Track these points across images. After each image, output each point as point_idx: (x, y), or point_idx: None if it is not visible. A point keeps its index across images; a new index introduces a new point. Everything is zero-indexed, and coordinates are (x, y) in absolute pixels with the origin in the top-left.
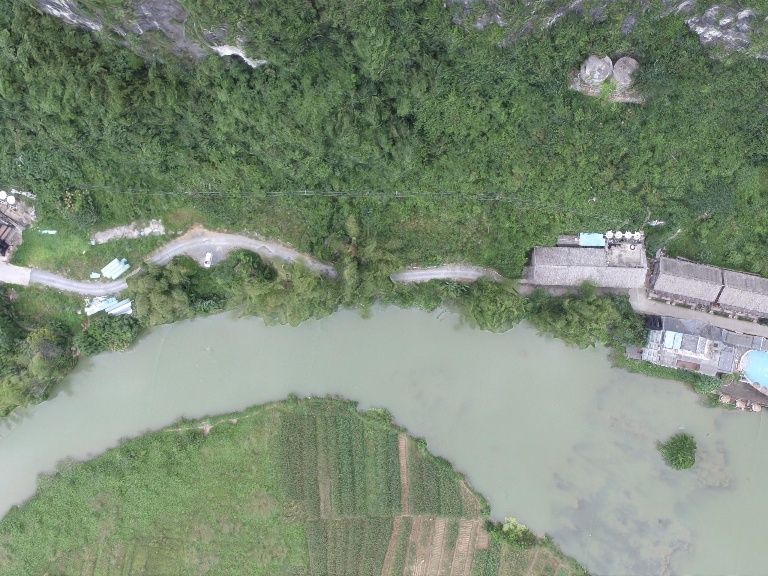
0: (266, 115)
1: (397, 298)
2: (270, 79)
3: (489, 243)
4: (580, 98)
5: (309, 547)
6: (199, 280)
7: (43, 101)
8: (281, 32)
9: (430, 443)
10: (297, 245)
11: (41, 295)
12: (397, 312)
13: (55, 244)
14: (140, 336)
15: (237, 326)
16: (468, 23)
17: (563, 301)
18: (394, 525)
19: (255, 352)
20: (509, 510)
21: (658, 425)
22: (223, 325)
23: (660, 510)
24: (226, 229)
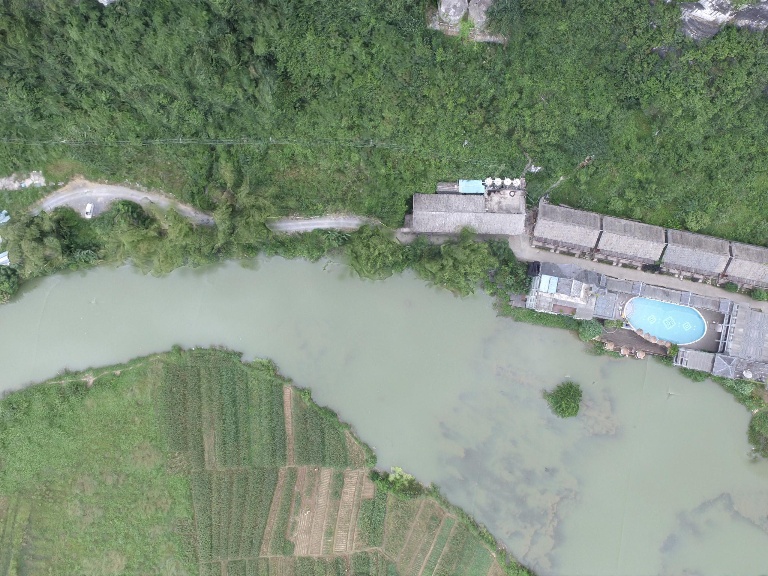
0: (122, 55)
1: (279, 248)
2: (122, 17)
3: (369, 191)
4: (440, 37)
5: (193, 498)
6: (79, 231)
7: None
8: None
9: (316, 394)
10: (179, 196)
11: None
12: (282, 263)
13: None
14: (24, 289)
15: (124, 279)
16: None
17: None
18: (279, 475)
19: (141, 304)
20: (395, 460)
21: (544, 373)
22: (109, 278)
23: (547, 459)
24: (107, 180)
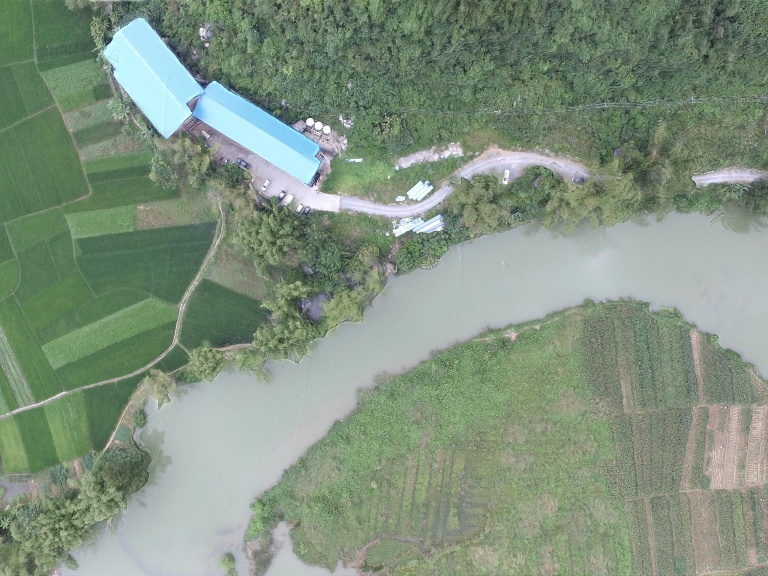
0: (609, 22)
1: (683, 202)
2: None
3: (767, 144)
4: None
5: (616, 441)
6: (501, 196)
7: (406, 20)
8: None
9: None
10: (586, 159)
11: (352, 220)
12: (676, 218)
13: (362, 171)
14: None
15: (523, 242)
16: None
17: None
18: (692, 415)
19: (546, 264)
20: None
21: None
22: (513, 241)
23: None
24: (521, 147)
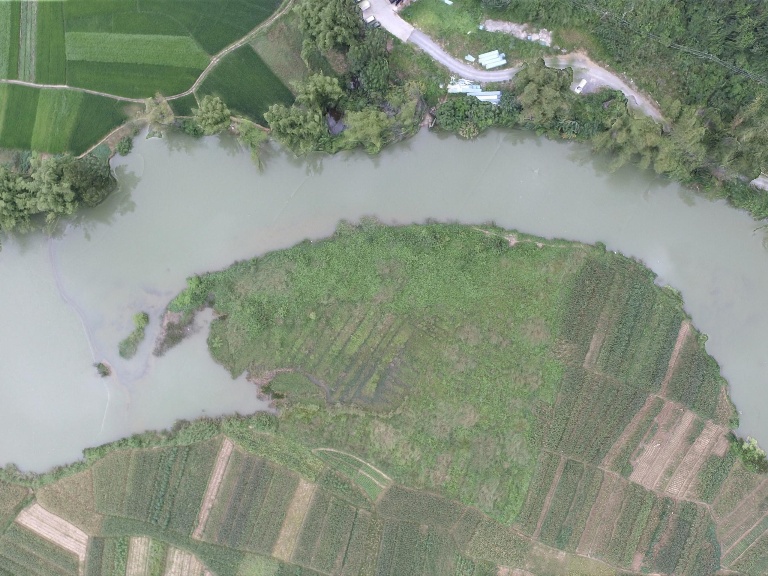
0: None
1: (738, 193)
2: None
3: None
4: None
5: (562, 388)
6: None
7: None
8: None
9: None
10: (665, 107)
11: (415, 55)
12: (723, 209)
13: (446, 14)
14: (482, 133)
15: (565, 163)
16: None
17: None
18: (646, 400)
19: (577, 192)
20: (754, 431)
21: None
22: (557, 155)
23: None
24: (608, 65)
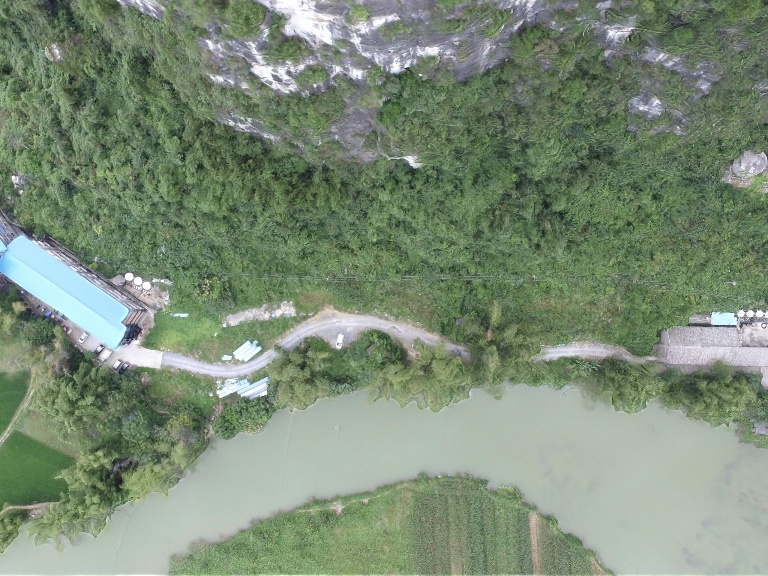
0: (423, 213)
1: None
2: (431, 179)
3: (620, 322)
4: (730, 190)
5: None
6: (332, 362)
7: (203, 202)
8: (467, 147)
9: (559, 520)
10: (427, 325)
11: (173, 378)
12: (524, 389)
13: (187, 327)
14: None
15: (363, 403)
16: (643, 131)
17: (697, 381)
18: None
19: (383, 430)
20: None
21: None
22: (350, 403)
23: None
24: (357, 310)
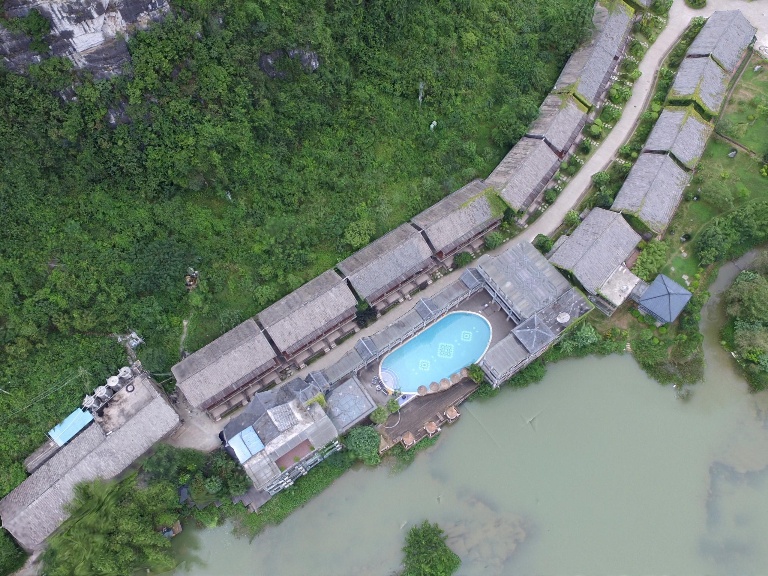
0: None
1: None
2: None
3: None
4: None
5: None
6: None
7: None
8: None
9: None
10: None
11: None
12: None
13: None
14: None
15: None
16: None
17: None
18: None
19: None
20: None
21: (373, 552)
22: None
23: None
24: None
